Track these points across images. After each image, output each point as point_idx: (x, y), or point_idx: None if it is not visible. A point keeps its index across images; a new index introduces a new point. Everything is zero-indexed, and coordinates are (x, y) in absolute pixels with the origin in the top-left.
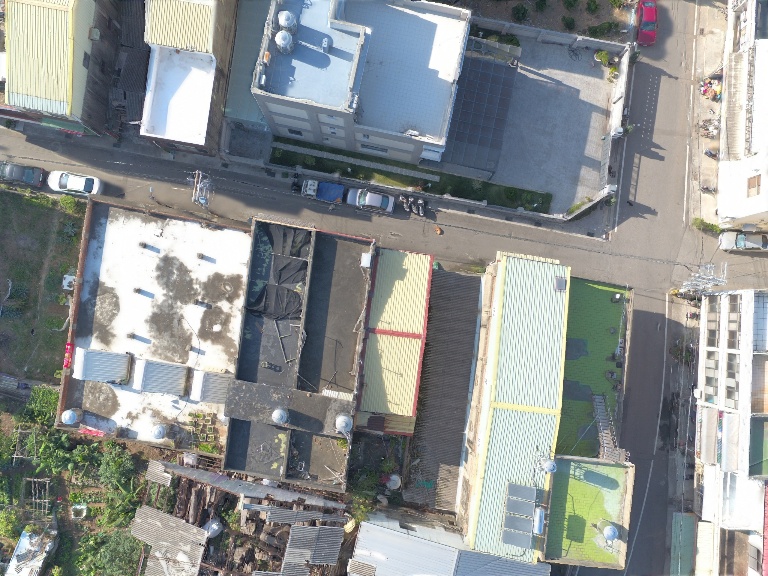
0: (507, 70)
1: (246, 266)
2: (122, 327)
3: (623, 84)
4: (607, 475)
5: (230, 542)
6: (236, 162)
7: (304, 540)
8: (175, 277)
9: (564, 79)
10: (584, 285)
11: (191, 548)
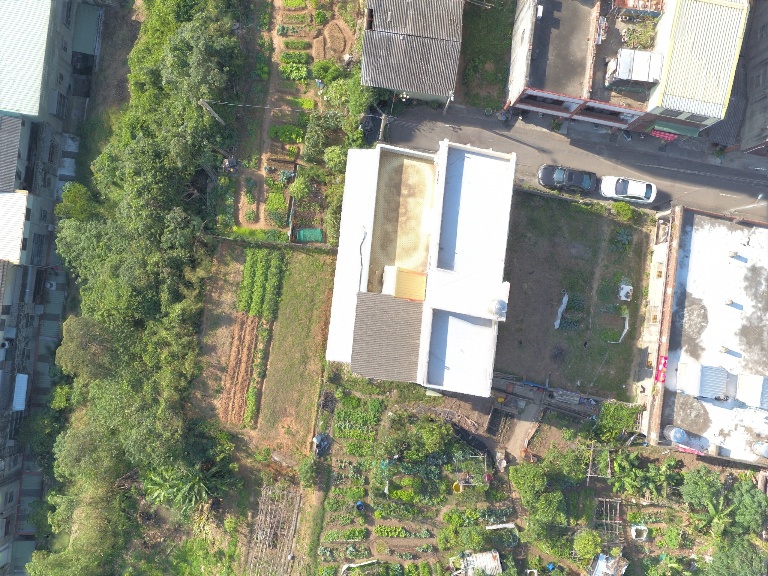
0: None
1: None
2: (711, 340)
3: None
4: None
5: None
6: None
7: None
8: (763, 288)
9: None
10: None
11: None
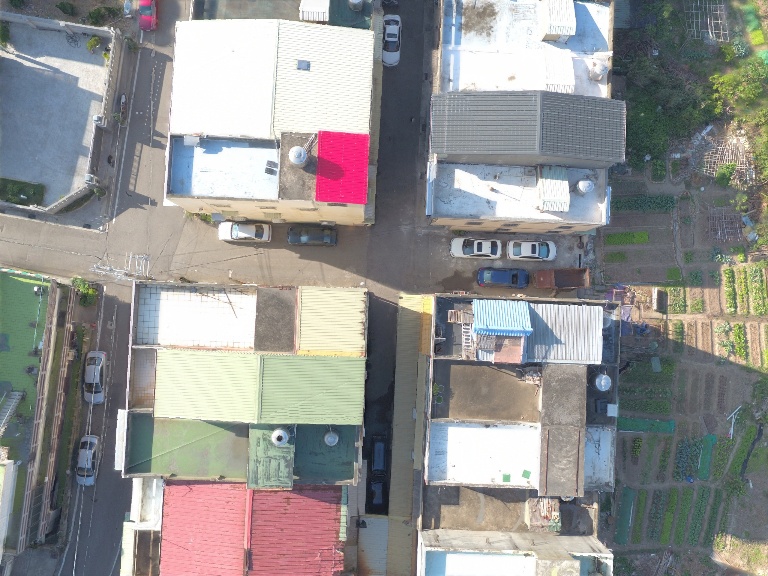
0: None
1: None
2: None
3: (107, 71)
4: None
5: None
6: None
7: None
8: None
9: (62, 66)
10: (7, 278)
11: None
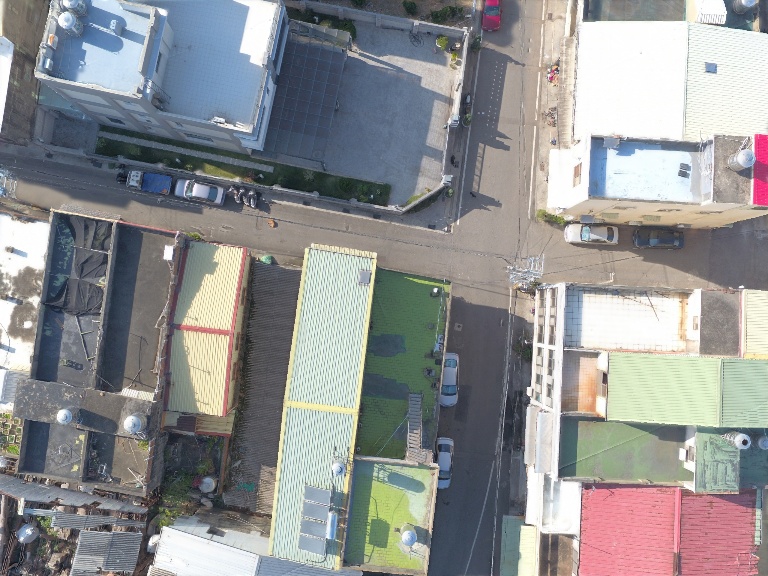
0: (335, 56)
1: (44, 259)
2: None
3: None
4: (412, 477)
5: (47, 548)
6: (60, 152)
7: (95, 546)
8: None
9: (405, 66)
10: (402, 279)
11: None
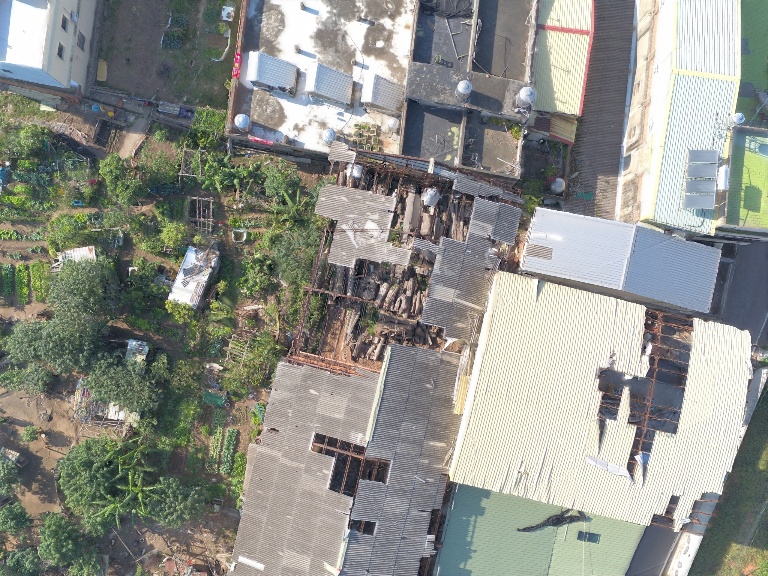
0: None
1: None
2: (288, 43)
3: None
4: None
5: None
6: None
7: (486, 214)
8: None
9: None
10: None
11: (380, 216)
